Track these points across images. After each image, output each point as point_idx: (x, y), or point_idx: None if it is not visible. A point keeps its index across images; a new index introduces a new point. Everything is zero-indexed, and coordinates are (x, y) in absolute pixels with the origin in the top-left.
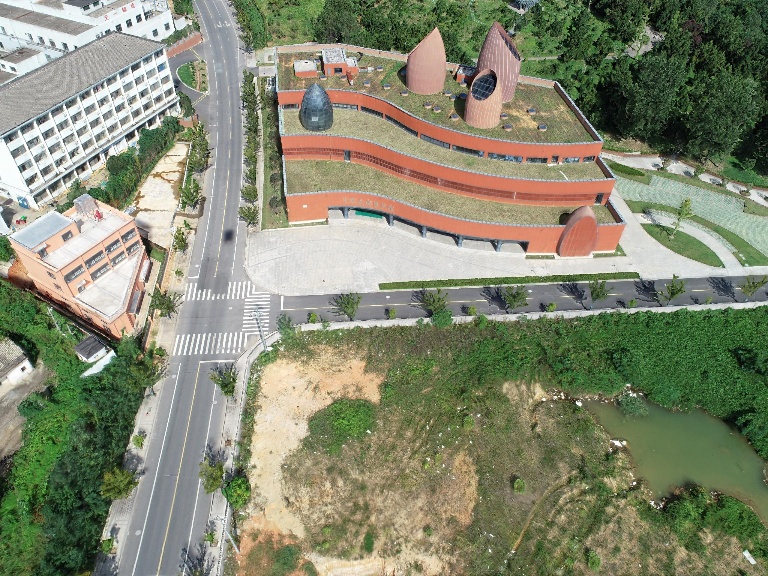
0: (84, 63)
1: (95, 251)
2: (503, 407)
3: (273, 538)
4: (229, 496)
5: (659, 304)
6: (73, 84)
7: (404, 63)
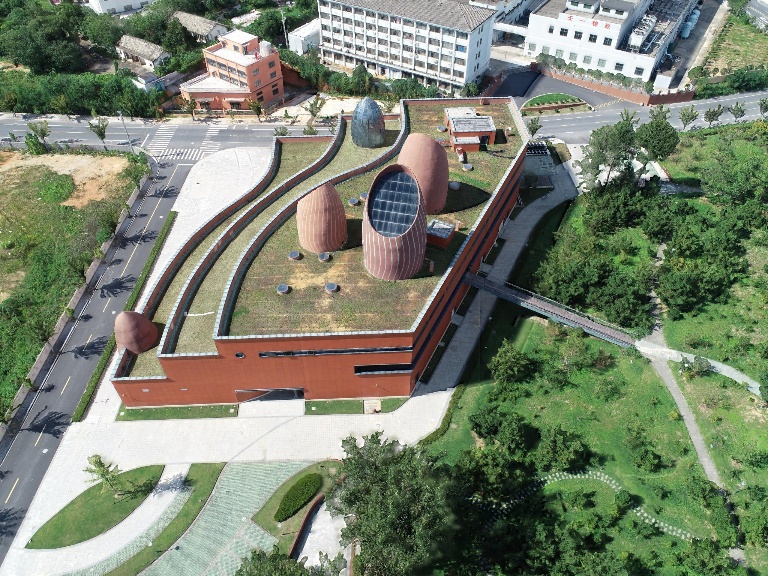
0: (413, 2)
1: (223, 62)
2: (5, 268)
3: (2, 162)
4: (26, 137)
5: (24, 428)
6: (385, 5)
7: (490, 189)
